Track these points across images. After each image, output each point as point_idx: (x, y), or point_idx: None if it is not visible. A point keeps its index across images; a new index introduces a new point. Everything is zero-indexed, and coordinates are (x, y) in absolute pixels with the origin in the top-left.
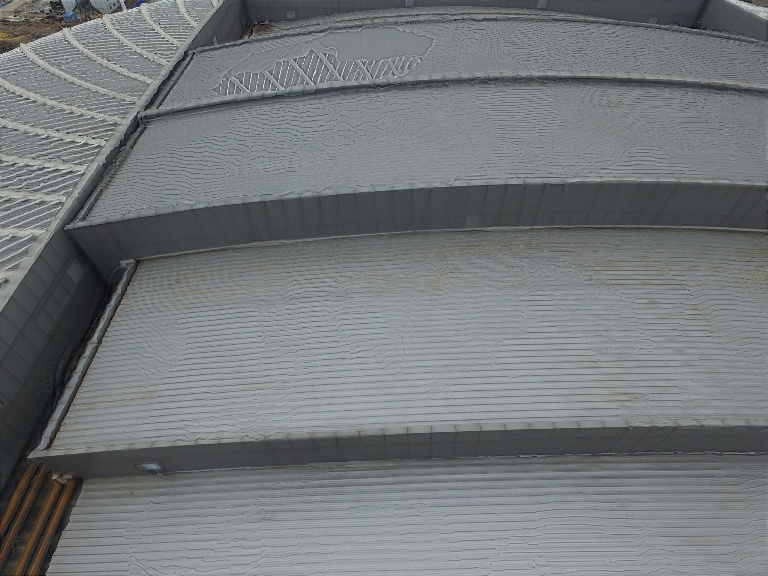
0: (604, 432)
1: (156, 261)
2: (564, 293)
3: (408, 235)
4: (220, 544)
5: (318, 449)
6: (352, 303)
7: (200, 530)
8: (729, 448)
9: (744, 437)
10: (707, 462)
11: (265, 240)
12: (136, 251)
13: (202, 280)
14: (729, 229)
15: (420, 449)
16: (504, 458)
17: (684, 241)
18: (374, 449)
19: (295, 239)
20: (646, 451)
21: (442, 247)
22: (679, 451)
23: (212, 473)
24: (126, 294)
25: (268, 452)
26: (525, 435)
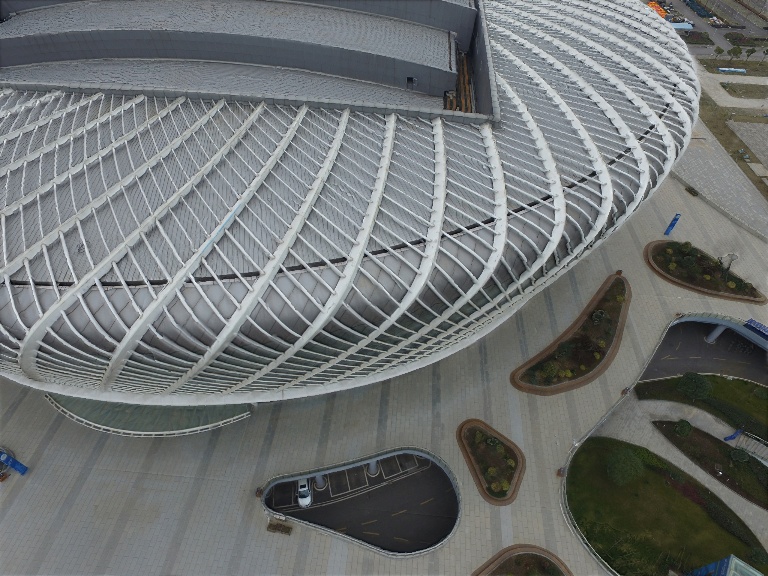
0: (143, 34)
1: (25, 13)
2: (165, 4)
3: (131, 0)
4: (7, 75)
5: (47, 45)
6: (81, 7)
7: (2, 74)
8: (209, 57)
9: (202, 44)
10: (202, 64)
11: (70, 2)
12: (15, 6)
13: (38, 14)
14: (277, 1)
15: (85, 47)
16: (124, 61)
17: (249, 2)
18: (68, 46)
19: (82, 0)
20: (176, 57)
21: (139, 0)
22: (191, 59)
23: (18, 69)
24: (6, 21)
25: (30, 47)
26: (116, 36)
